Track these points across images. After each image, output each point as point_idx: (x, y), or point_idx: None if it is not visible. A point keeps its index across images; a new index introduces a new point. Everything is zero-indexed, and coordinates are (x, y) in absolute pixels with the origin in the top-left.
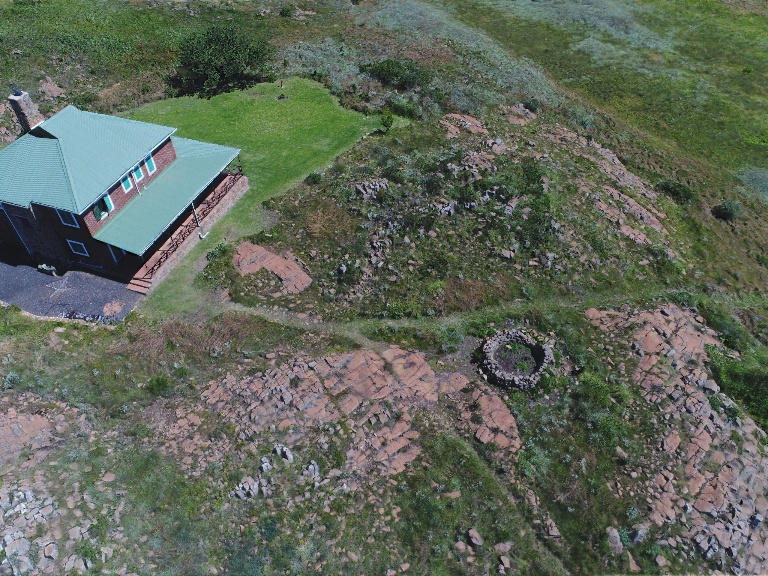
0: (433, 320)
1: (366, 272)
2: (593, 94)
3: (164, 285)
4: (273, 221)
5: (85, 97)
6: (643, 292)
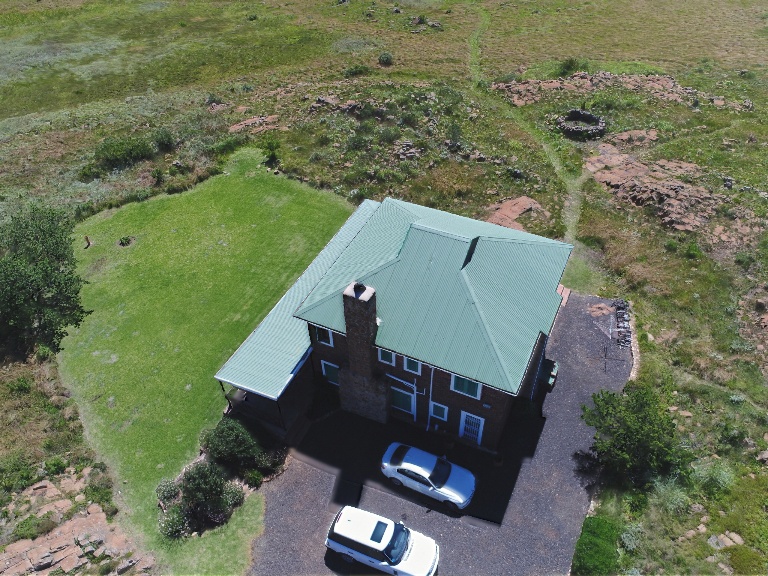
0: None
1: None
2: (185, 84)
3: None
4: None
5: (11, 468)
6: None
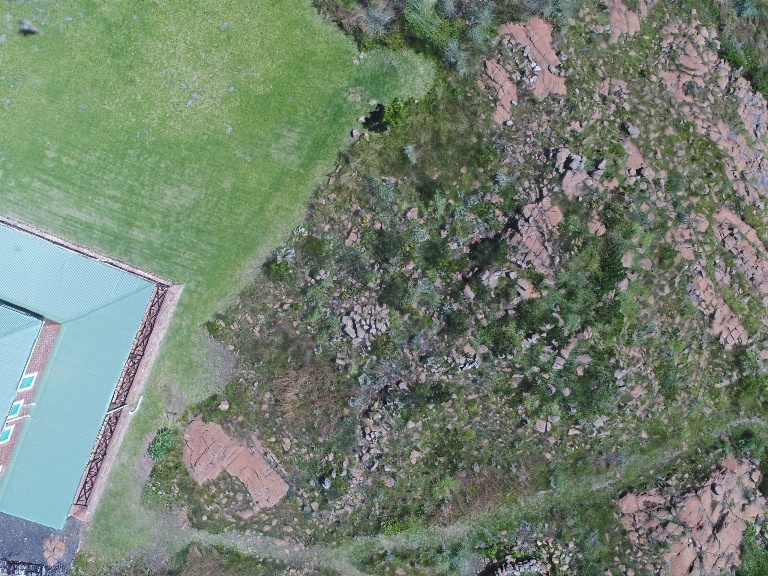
0: (435, 532)
1: (356, 477)
2: None
3: (105, 501)
4: (227, 369)
5: None
6: (703, 433)
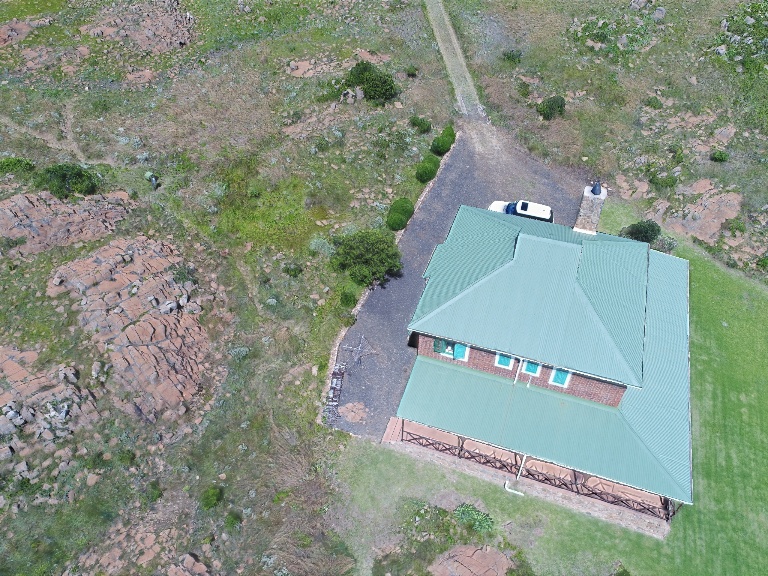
0: None
1: None
2: None
3: (403, 460)
4: None
5: None
6: None
